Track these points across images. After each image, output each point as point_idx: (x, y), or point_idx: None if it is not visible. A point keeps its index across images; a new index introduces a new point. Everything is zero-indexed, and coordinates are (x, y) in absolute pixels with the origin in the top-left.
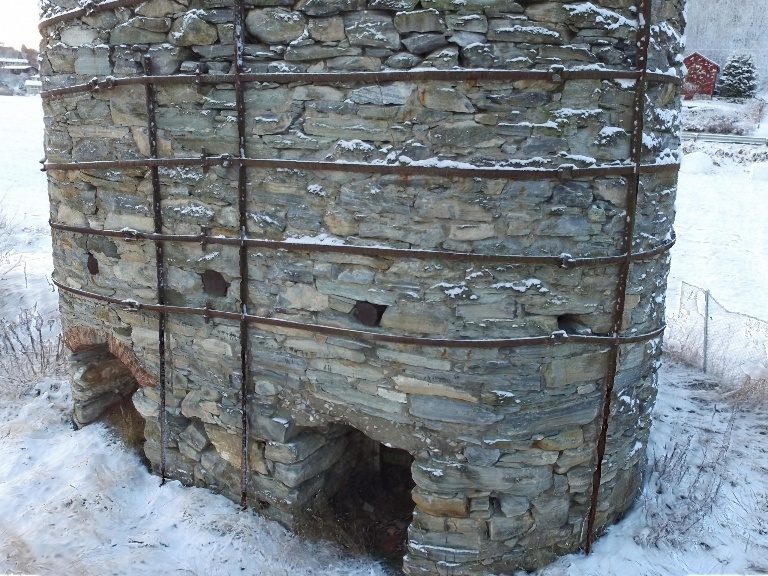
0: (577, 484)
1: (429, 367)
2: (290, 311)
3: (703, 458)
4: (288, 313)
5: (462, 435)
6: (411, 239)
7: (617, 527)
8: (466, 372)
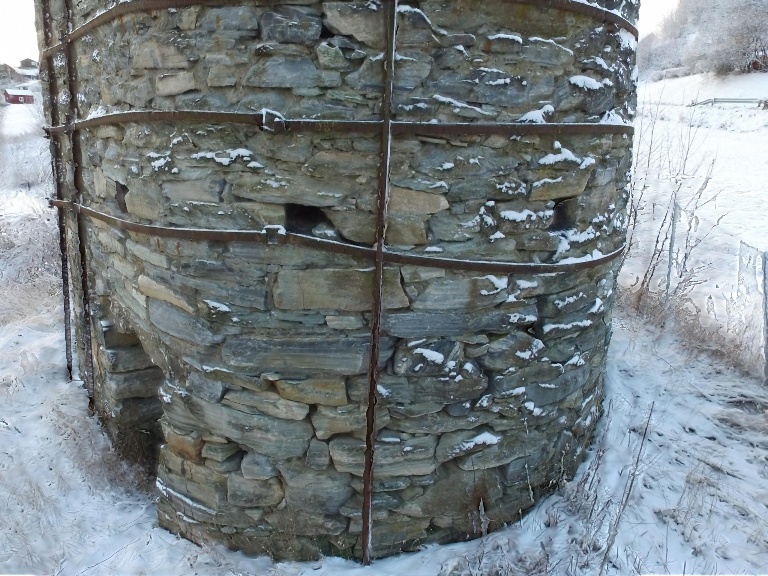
0: (343, 460)
1: (151, 262)
2: (95, 199)
3: (672, 502)
4: (95, 201)
5: (186, 355)
6: (129, 98)
7: (437, 547)
8: (181, 272)
